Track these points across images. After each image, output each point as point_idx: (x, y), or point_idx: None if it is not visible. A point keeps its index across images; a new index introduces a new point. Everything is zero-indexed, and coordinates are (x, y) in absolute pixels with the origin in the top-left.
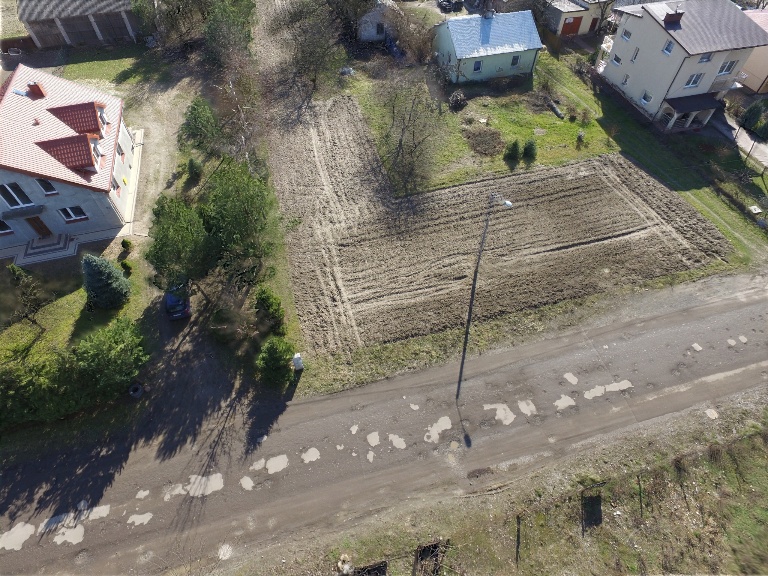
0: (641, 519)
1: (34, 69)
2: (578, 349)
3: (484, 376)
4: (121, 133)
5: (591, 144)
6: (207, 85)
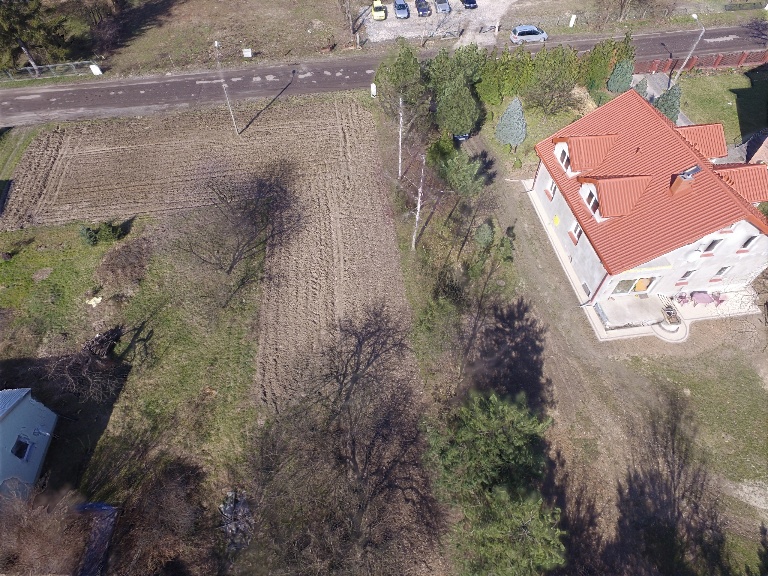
0: (236, 52)
1: (730, 221)
2: (209, 95)
3: (271, 89)
4: (592, 257)
5: (8, 245)
6: (547, 490)
